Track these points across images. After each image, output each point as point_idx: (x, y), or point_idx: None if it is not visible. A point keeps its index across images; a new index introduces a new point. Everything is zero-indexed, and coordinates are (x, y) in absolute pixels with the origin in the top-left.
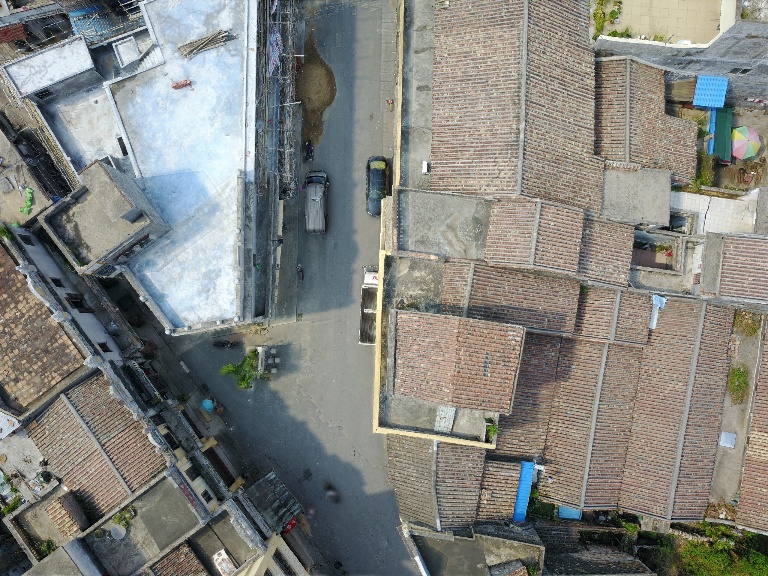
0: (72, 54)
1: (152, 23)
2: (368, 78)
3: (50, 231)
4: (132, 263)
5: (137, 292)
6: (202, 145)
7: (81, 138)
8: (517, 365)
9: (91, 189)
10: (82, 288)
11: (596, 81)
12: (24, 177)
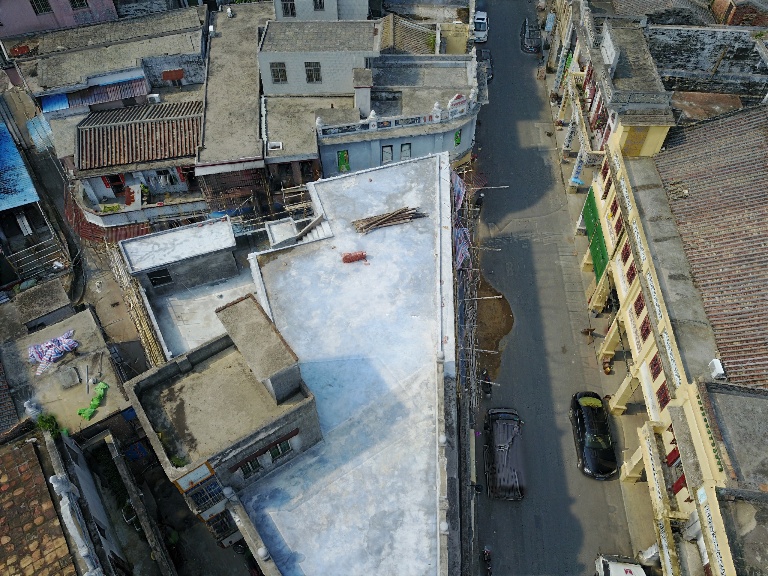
0: (211, 233)
1: (321, 200)
2: (552, 307)
3: (139, 405)
4: (247, 493)
5: (253, 542)
6: (378, 326)
7: (190, 336)
8: None
9: (233, 332)
10: (134, 553)
11: None
12: (101, 368)
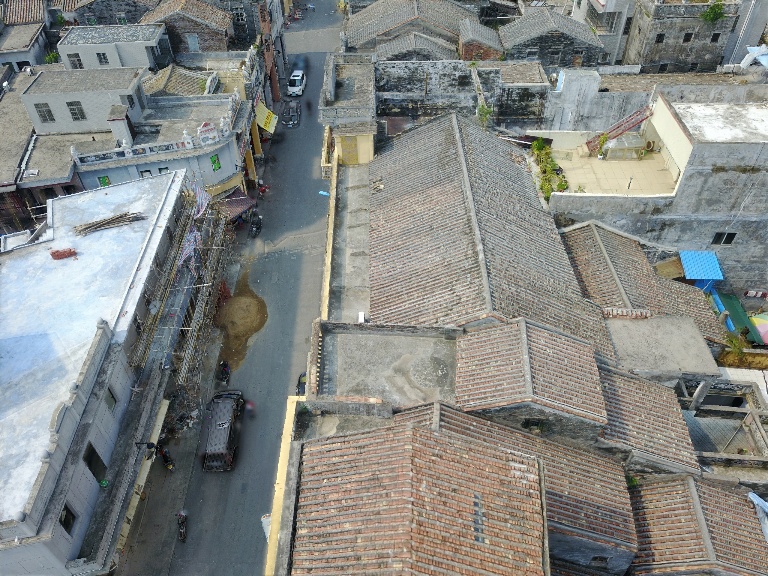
0: None
1: (54, 212)
2: (305, 306)
3: None
4: None
5: None
6: (65, 307)
7: None
8: (541, 527)
9: None
10: None
11: None
12: None
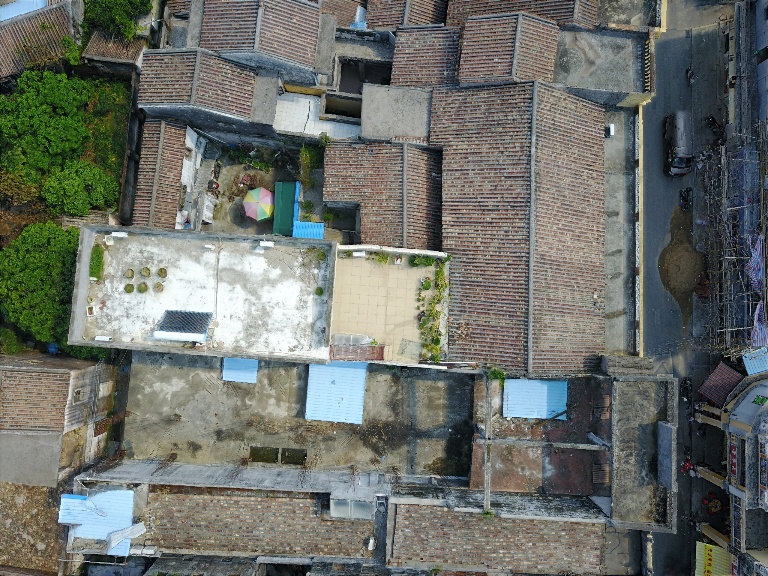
0: None
1: None
2: None
3: None
4: None
5: None
6: None
7: None
8: None
9: None
10: None
11: (432, 232)
12: None
